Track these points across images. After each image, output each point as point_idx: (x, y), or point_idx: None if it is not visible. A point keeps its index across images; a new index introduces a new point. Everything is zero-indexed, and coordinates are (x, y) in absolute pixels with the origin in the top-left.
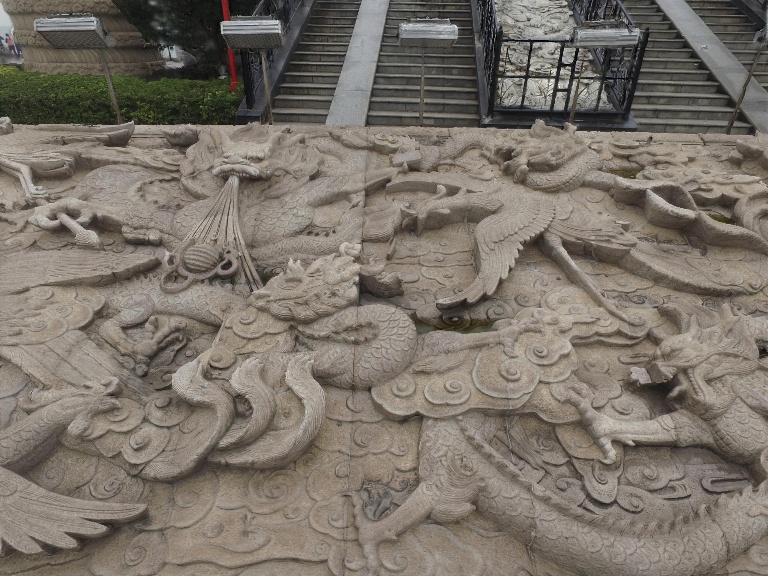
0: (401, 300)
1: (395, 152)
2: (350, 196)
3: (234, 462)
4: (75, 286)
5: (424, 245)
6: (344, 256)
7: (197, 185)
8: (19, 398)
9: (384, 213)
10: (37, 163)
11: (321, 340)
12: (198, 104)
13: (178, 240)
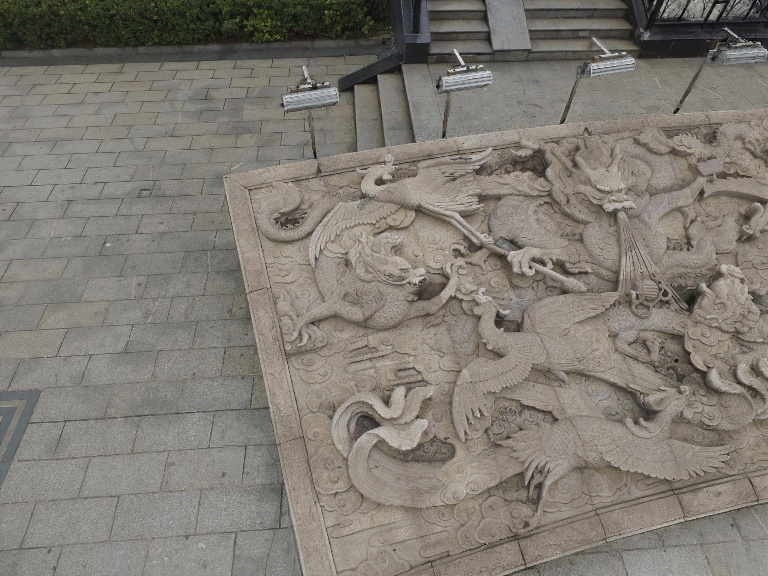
0: (762, 300)
1: (690, 155)
2: (684, 209)
3: (762, 419)
4: (584, 320)
5: (750, 250)
6: (729, 277)
7: (577, 212)
8: (614, 397)
9: (725, 230)
10: (465, 210)
11: (755, 343)
12: (318, 6)
13: (602, 268)
